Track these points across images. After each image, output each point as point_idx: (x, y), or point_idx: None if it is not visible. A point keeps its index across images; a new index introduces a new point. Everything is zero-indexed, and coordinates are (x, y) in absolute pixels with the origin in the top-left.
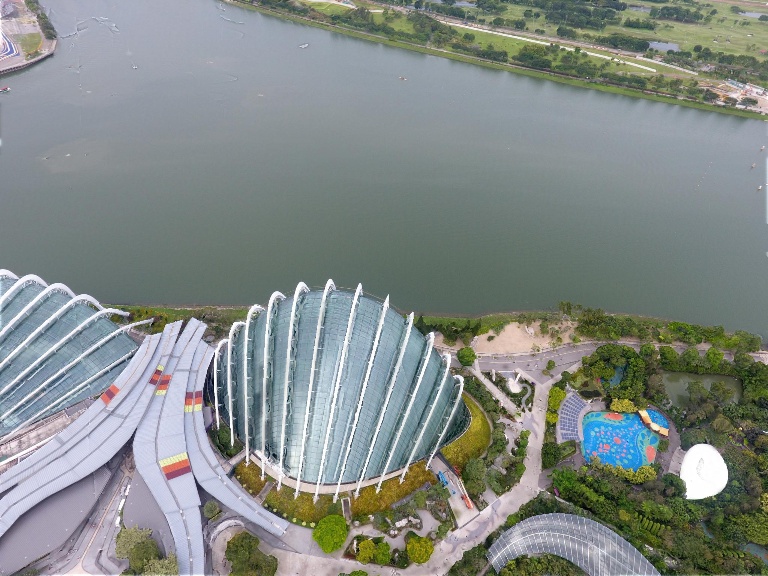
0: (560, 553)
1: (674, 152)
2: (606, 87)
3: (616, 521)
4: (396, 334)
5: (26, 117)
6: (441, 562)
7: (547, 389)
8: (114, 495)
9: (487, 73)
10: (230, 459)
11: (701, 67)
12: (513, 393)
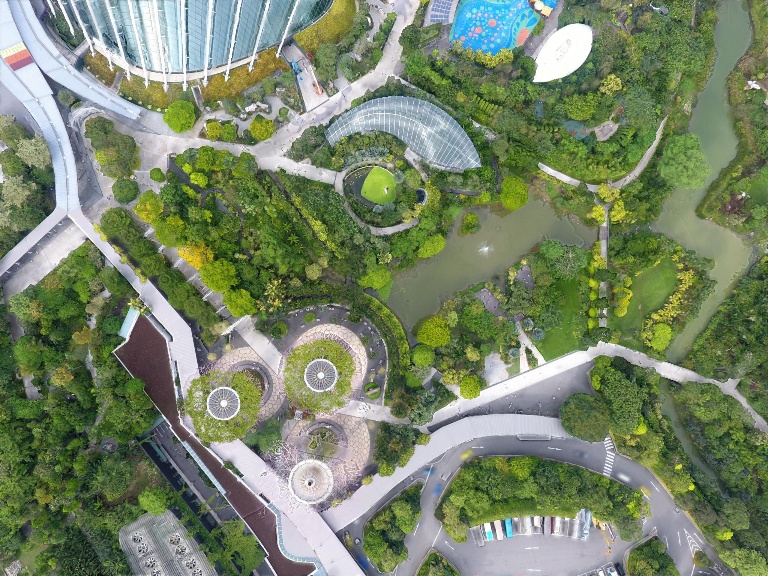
0: (389, 130)
1: None
2: None
3: (452, 103)
4: None
5: None
6: (287, 140)
7: None
8: None
9: None
10: (74, 49)
11: None
12: None
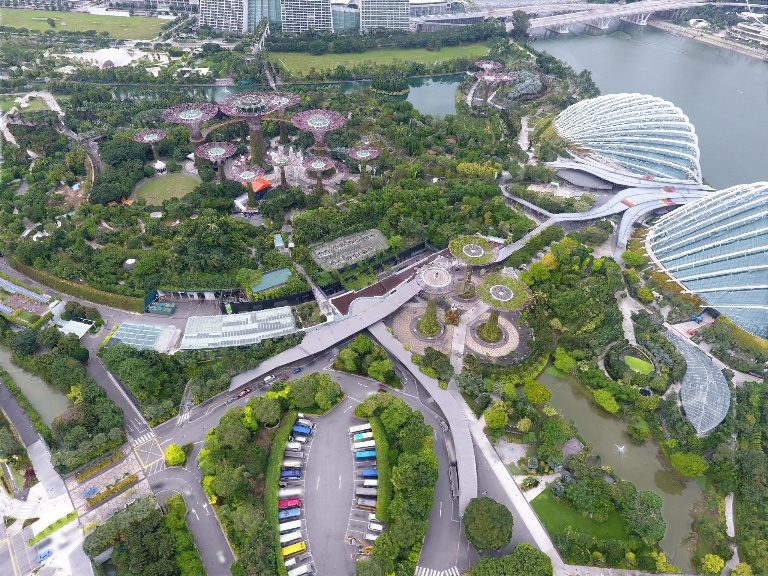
0: (689, 364)
1: None
2: None
3: None
4: None
5: None
6: None
7: None
8: (602, 195)
9: None
10: None
11: None
12: None
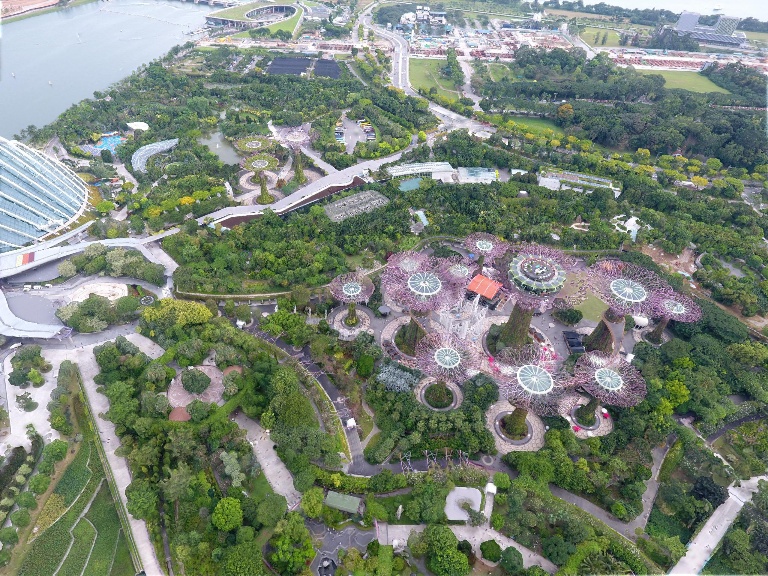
0: (149, 156)
1: None
2: None
3: None
4: (1, 145)
5: None
6: None
7: (70, 158)
8: None
9: None
10: None
11: None
12: None
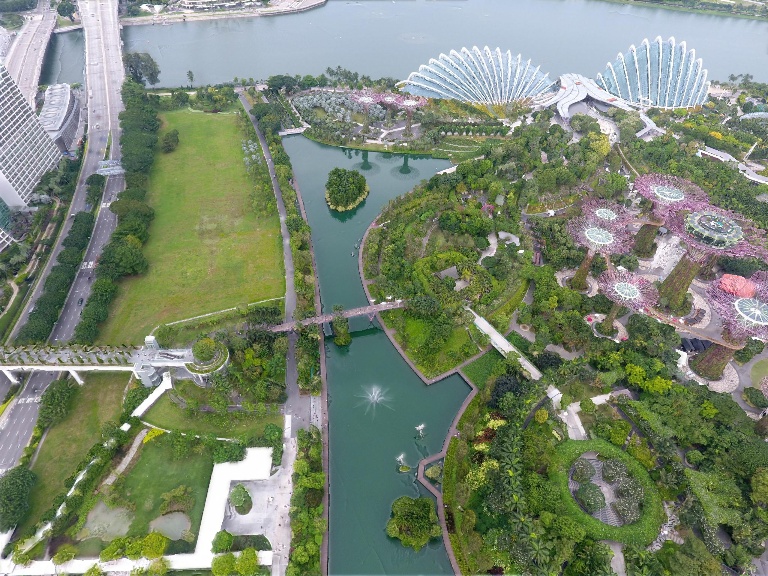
0: None
1: (761, 38)
2: (704, 11)
3: None
4: None
5: (363, 24)
6: None
7: (734, 100)
8: None
9: (615, 7)
10: None
11: (766, 0)
12: (721, 99)
